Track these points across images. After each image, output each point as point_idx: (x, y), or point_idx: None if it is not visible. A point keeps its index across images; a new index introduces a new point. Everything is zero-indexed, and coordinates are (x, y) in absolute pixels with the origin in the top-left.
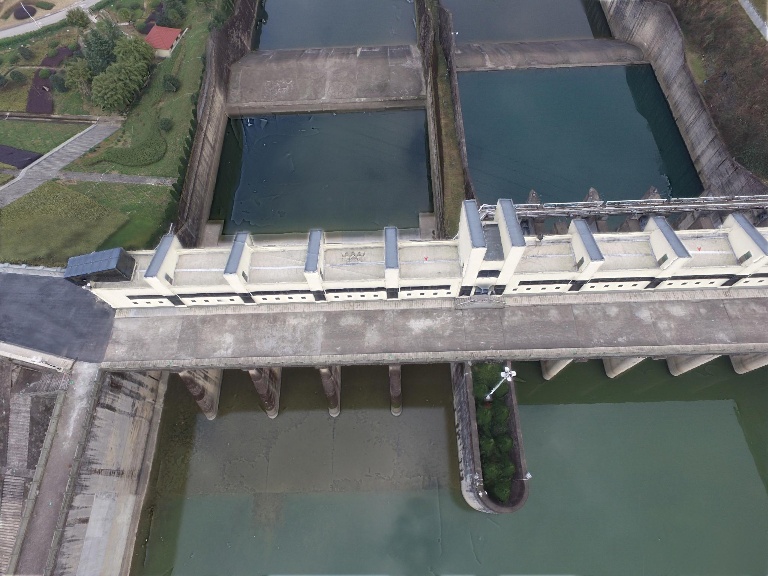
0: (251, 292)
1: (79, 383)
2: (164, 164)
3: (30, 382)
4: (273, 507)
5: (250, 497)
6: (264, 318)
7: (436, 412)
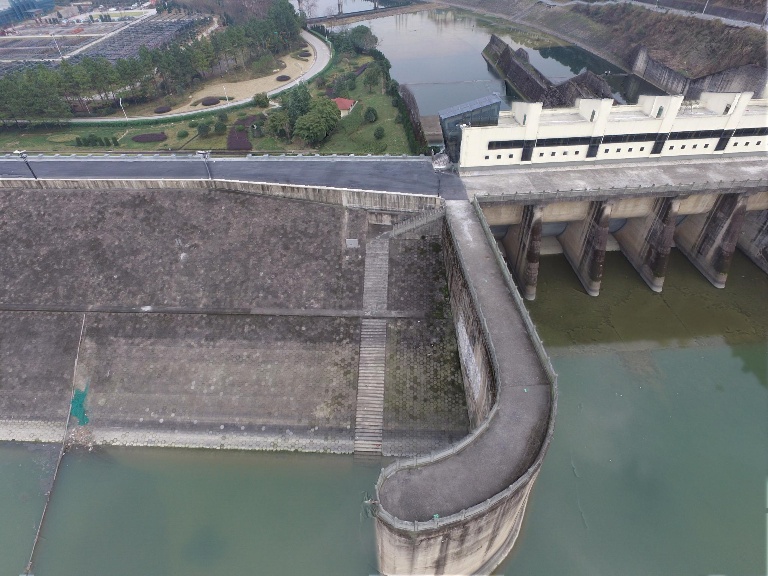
0: (604, 136)
1: (455, 211)
2: None
3: (382, 231)
4: (645, 362)
5: (613, 356)
6: (604, 172)
7: (759, 285)
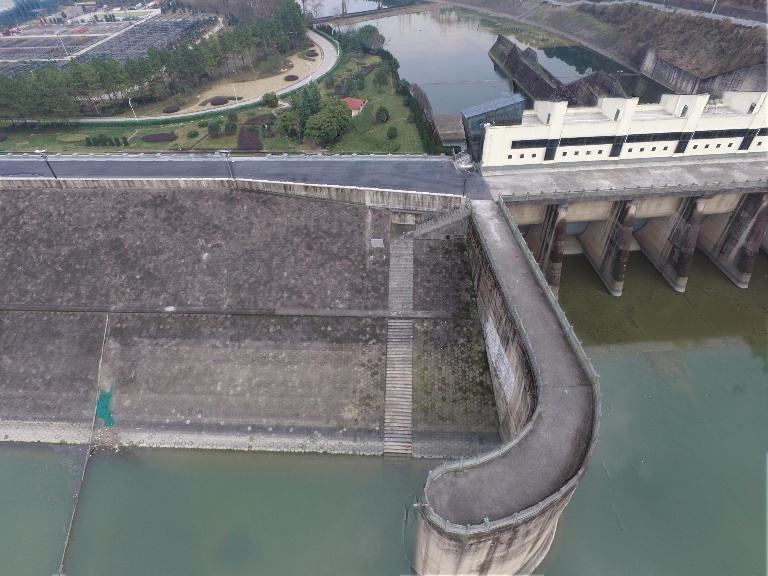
0: (628, 135)
1: (480, 210)
2: (403, 151)
3: (406, 231)
4: (672, 362)
5: (639, 356)
6: (627, 171)
7: None
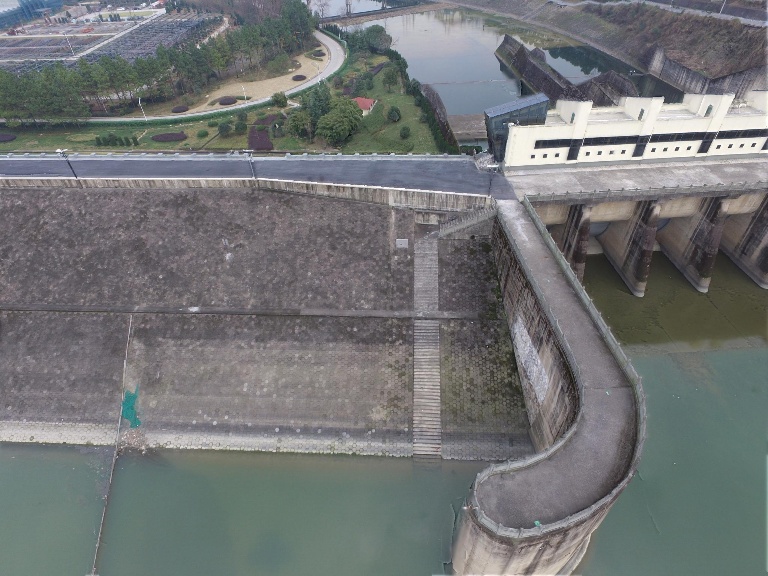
0: (652, 135)
1: (506, 210)
2: (417, 151)
3: (430, 231)
4: (699, 363)
5: (665, 357)
6: (650, 171)
7: None
